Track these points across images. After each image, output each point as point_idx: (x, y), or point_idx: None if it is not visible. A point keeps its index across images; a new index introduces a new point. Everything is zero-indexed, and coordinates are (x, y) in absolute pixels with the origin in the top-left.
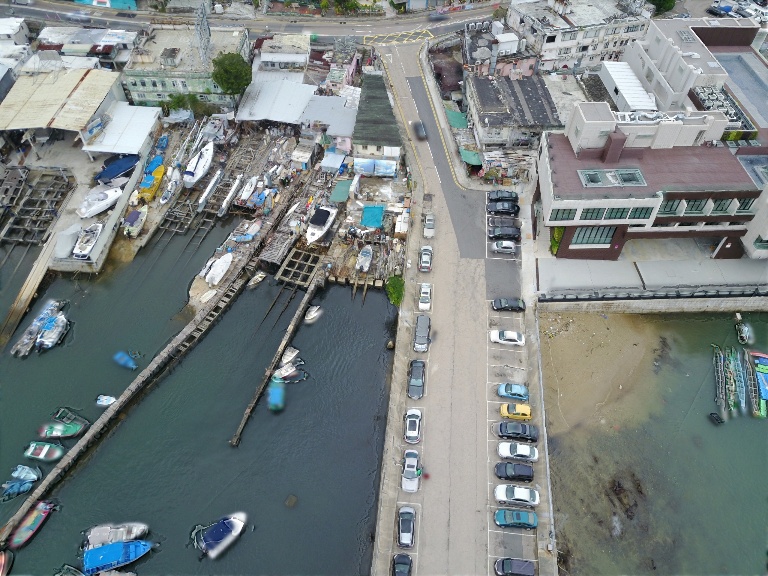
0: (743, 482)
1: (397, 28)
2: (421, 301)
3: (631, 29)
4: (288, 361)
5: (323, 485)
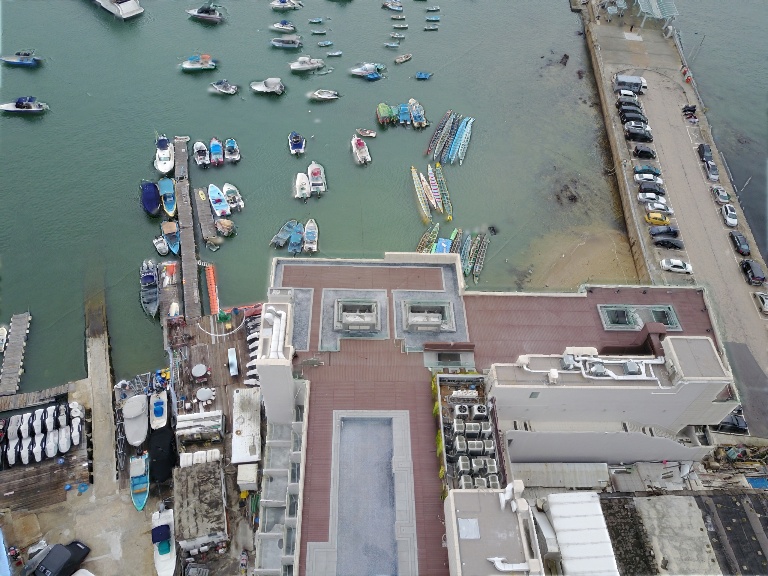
0: (485, 200)
1: None
2: (767, 296)
3: None
4: None
5: (764, 217)
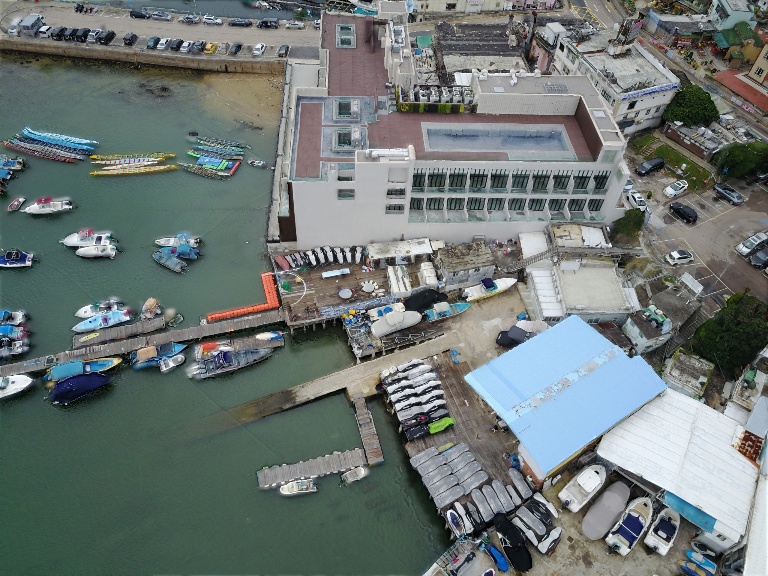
0: (151, 136)
1: (610, 21)
2: None
3: (607, 96)
4: (269, 3)
5: None
